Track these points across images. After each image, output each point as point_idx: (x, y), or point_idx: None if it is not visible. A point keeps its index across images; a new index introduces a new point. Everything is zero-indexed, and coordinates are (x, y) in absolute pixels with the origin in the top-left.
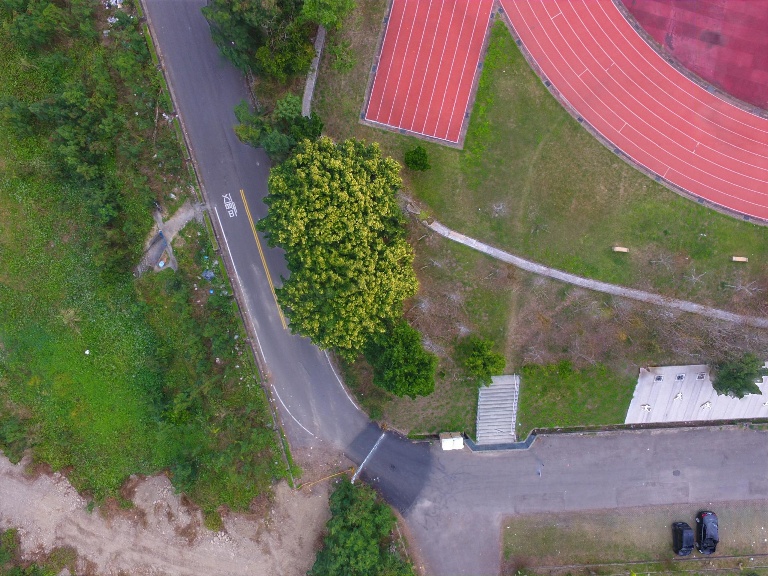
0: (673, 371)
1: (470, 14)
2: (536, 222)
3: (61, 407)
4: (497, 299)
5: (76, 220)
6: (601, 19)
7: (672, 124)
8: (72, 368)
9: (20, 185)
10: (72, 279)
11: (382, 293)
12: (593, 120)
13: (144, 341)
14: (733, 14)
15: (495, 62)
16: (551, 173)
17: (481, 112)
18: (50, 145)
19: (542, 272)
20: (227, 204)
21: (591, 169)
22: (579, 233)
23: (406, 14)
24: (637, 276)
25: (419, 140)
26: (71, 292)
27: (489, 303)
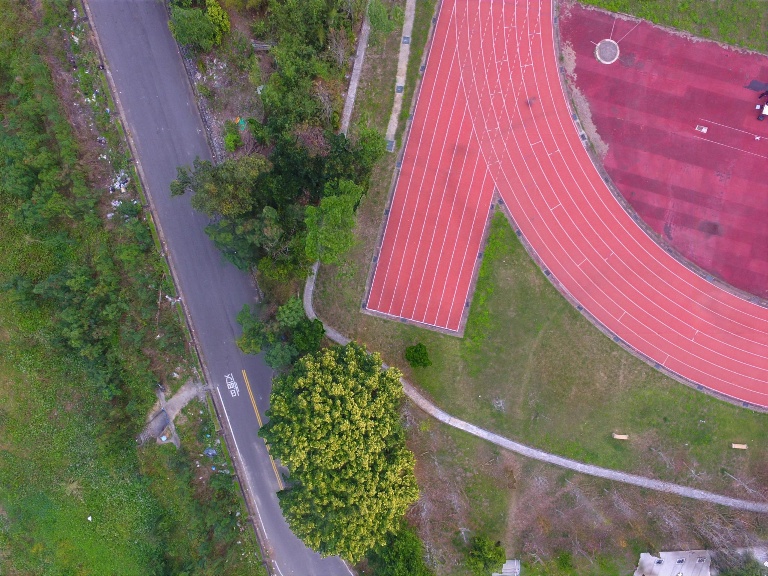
0: (673, 556)
1: (470, 206)
2: (536, 409)
3: (64, 574)
4: (498, 485)
5: (79, 389)
6: (600, 210)
7: (671, 312)
8: (75, 535)
9: (24, 356)
10: (75, 449)
11: (383, 510)
12: (592, 309)
13: (146, 509)
14: (731, 205)
15: (495, 252)
16: (551, 361)
17: (481, 301)
18: (54, 325)
19: (542, 458)
20: (229, 384)
21: (591, 356)
22: (579, 420)
23: (407, 206)
24: (637, 462)
25: (420, 329)
26: (74, 461)
27: (490, 489)
